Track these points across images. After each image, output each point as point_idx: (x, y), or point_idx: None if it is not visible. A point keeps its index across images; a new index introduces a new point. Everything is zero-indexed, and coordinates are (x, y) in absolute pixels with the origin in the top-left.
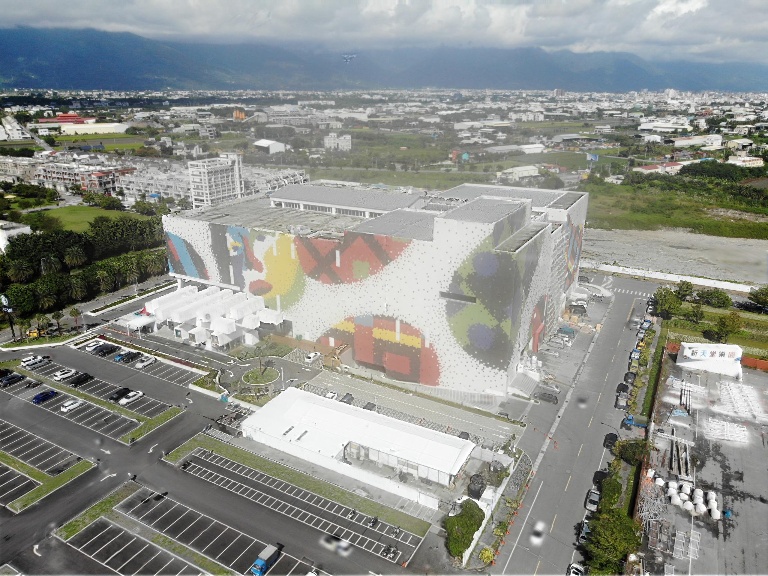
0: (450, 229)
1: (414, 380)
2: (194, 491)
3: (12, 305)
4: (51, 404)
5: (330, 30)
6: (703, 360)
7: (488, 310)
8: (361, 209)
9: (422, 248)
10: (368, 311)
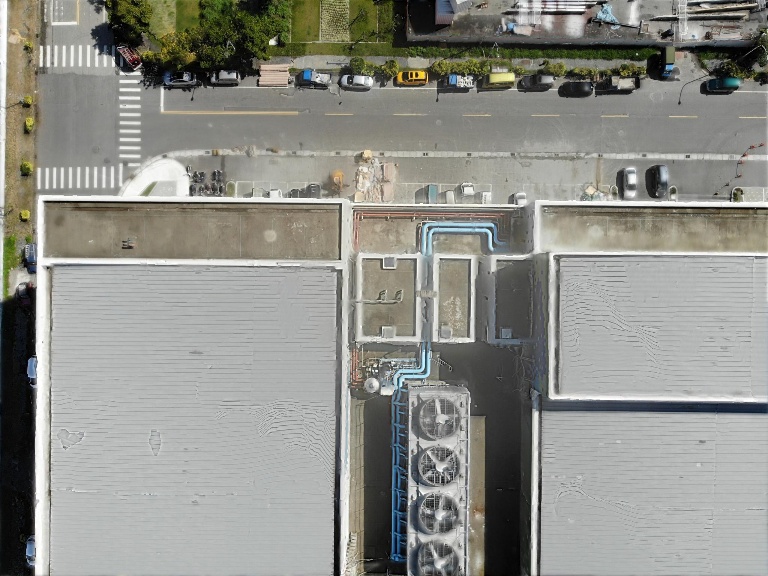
0: None
1: None
2: None
3: None
4: None
5: None
6: None
7: None
8: None
9: None
10: None
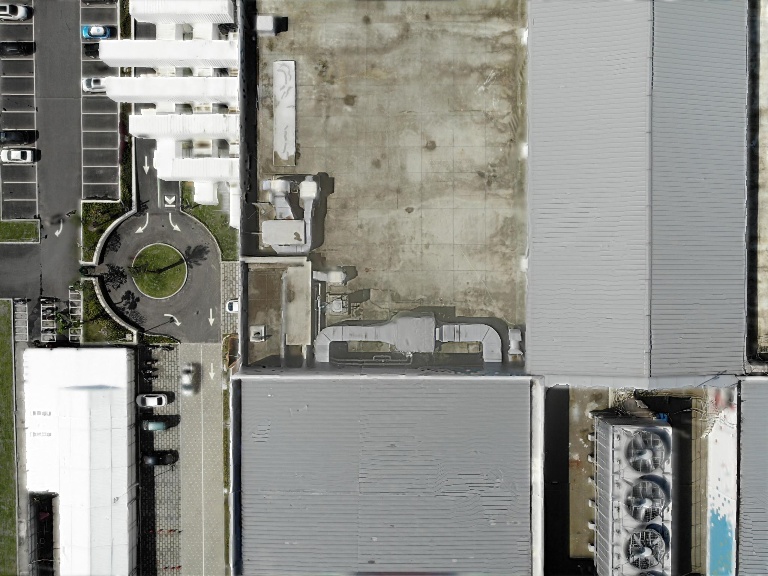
0: None
1: None
2: None
3: None
4: None
5: None
6: None
7: None
8: None
9: None
10: None
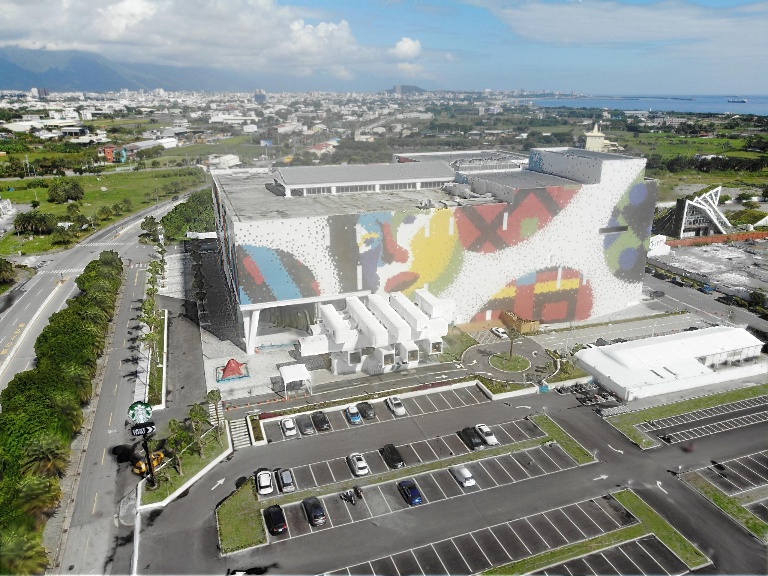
0: (615, 169)
1: (569, 321)
2: (716, 447)
3: (55, 441)
4: (434, 493)
5: None
6: (654, 249)
7: (636, 234)
8: (412, 180)
9: (589, 192)
10: (532, 268)
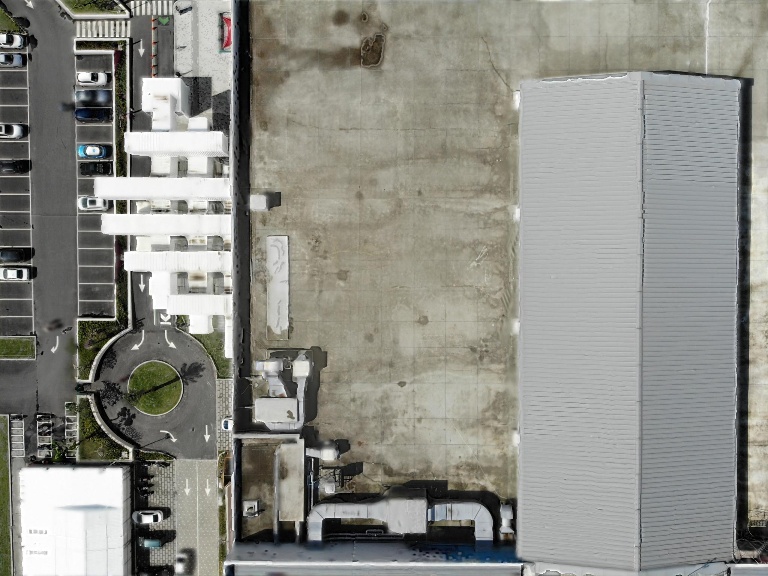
0: None
1: None
2: None
3: None
4: None
5: None
6: None
7: None
8: None
9: None
10: None
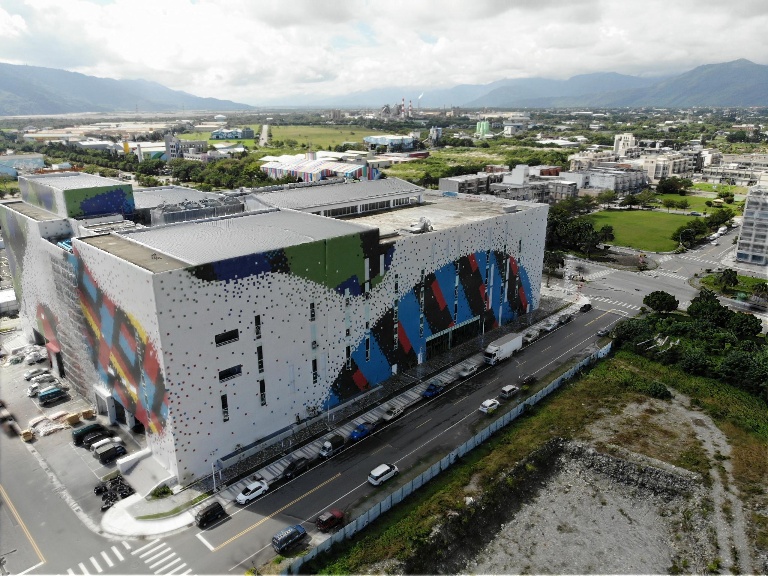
0: None
1: None
2: None
3: None
4: None
5: (128, 18)
6: None
7: None
8: None
9: None
10: None
